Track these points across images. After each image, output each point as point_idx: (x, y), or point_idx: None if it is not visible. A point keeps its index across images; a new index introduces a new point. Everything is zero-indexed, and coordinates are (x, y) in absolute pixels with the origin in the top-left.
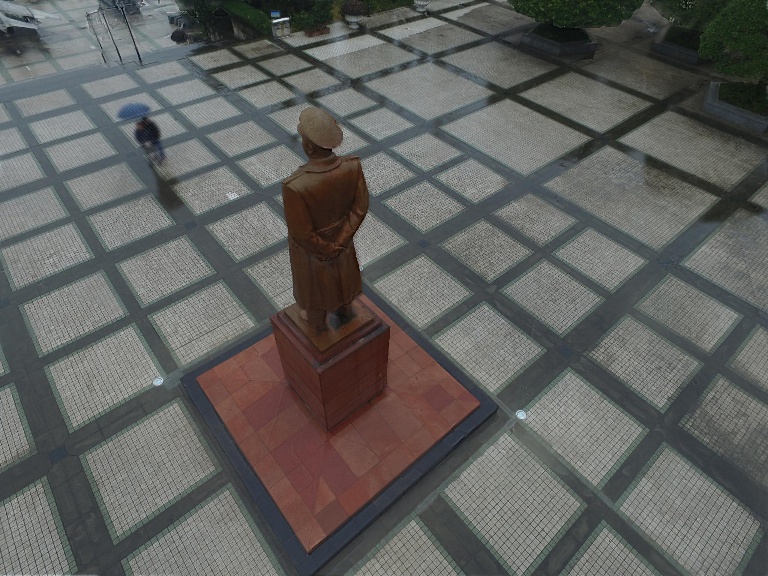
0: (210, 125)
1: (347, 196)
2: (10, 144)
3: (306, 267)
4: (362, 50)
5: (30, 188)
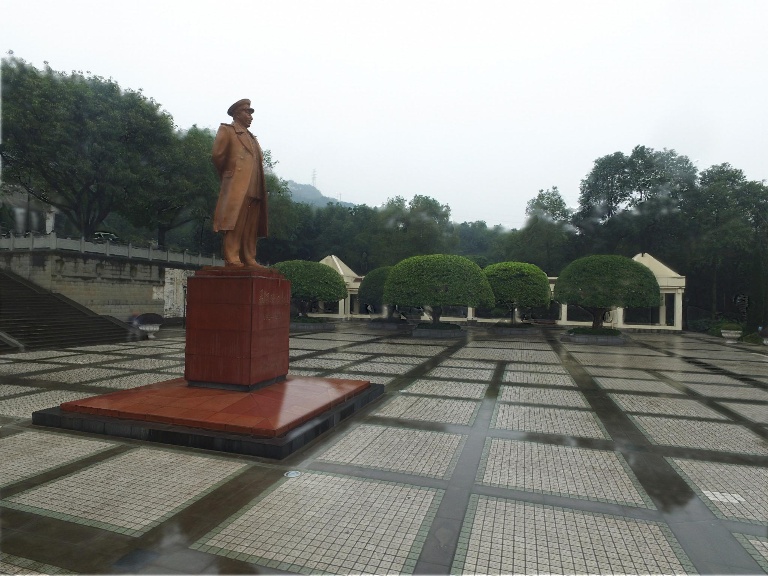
0: None
1: None
2: None
3: None
4: None
5: None
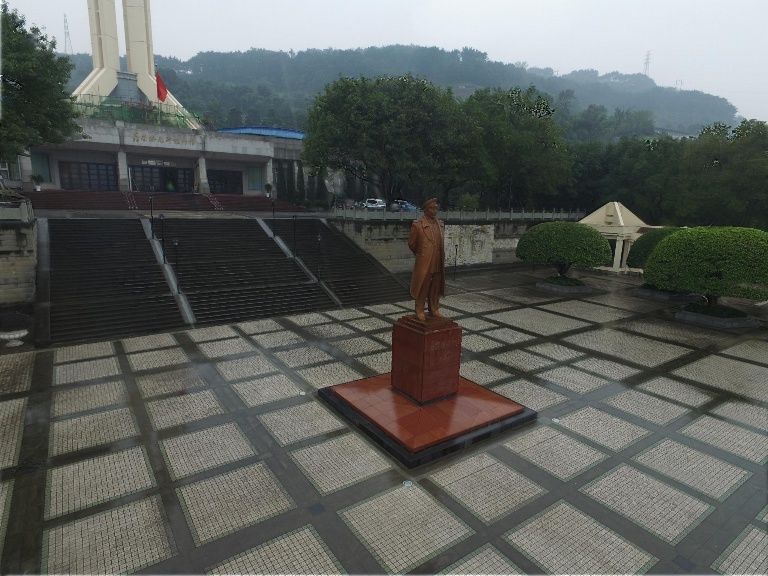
0: None
1: None
2: None
3: None
4: None
5: None
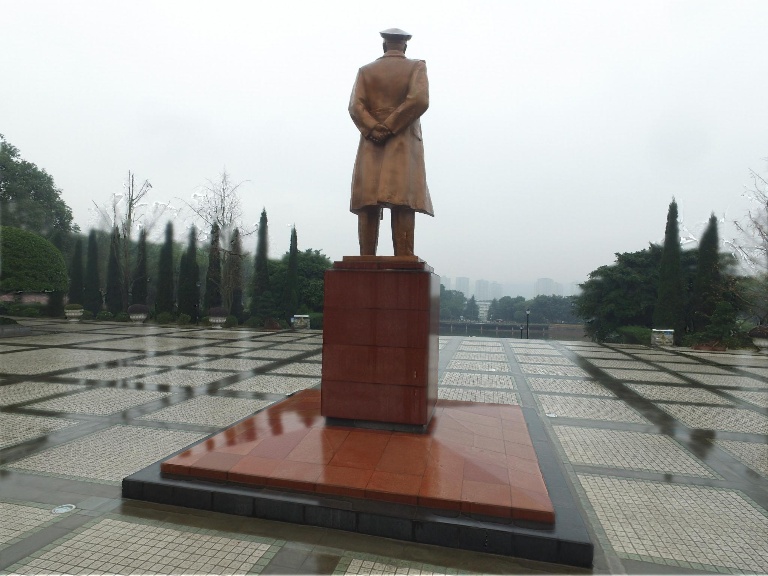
0: None
1: (400, 81)
2: None
3: (358, 152)
4: (759, 359)
5: None
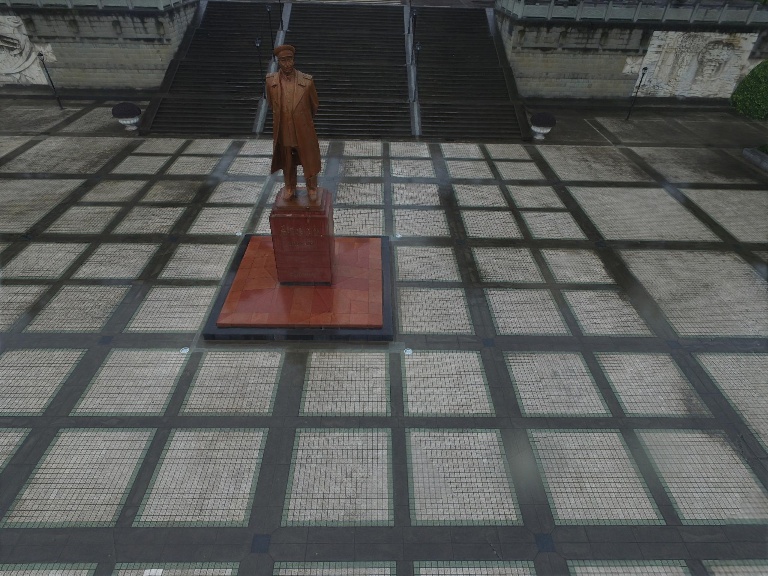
0: None
1: None
2: None
3: None
4: None
5: None
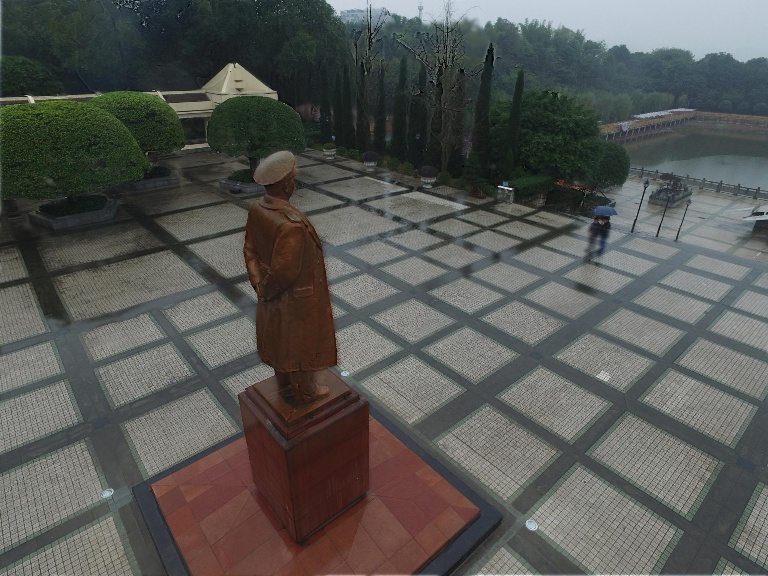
0: (725, 337)
1: None
2: (579, 250)
3: None
4: None
5: (534, 270)
